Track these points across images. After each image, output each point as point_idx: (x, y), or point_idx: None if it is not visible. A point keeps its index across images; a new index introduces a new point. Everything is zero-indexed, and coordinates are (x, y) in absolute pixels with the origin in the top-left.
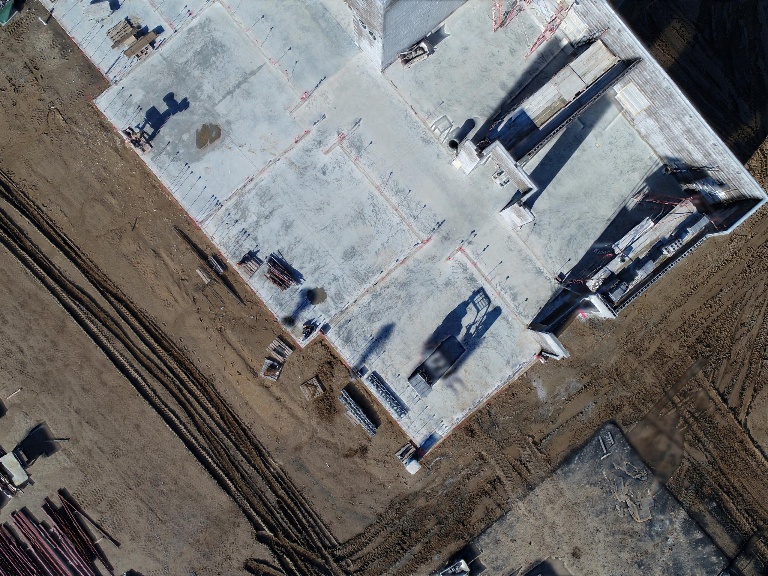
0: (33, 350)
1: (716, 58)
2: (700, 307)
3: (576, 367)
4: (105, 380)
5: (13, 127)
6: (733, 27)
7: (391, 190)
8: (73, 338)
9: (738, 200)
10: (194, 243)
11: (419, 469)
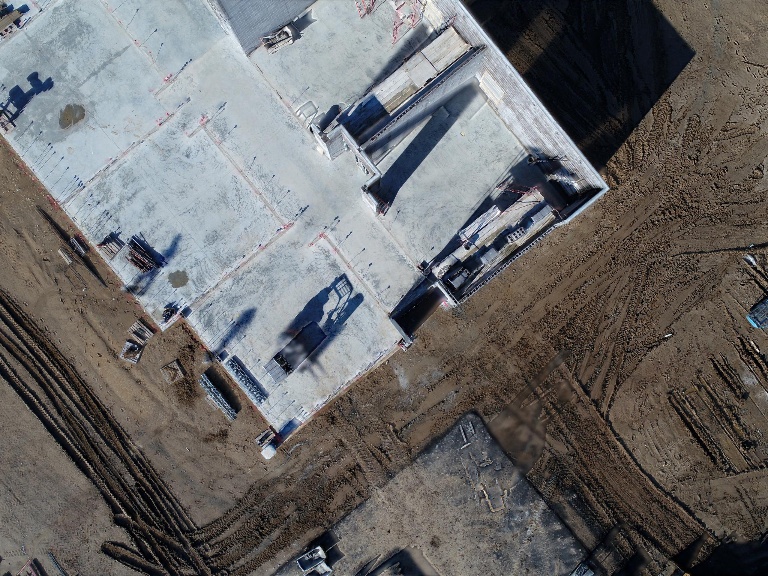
0: None
1: (585, 49)
2: (564, 298)
3: (438, 356)
4: None
5: None
6: (602, 19)
7: (255, 174)
8: None
9: (587, 190)
10: (56, 224)
11: (277, 455)
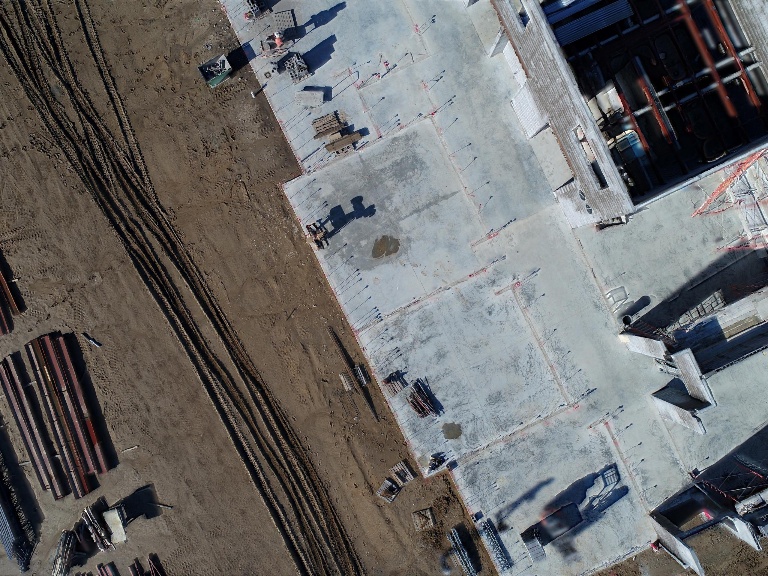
0: (159, 411)
1: None
2: None
3: None
4: (222, 459)
5: (196, 189)
6: None
7: (551, 346)
8: (201, 410)
9: None
10: (344, 348)
11: None
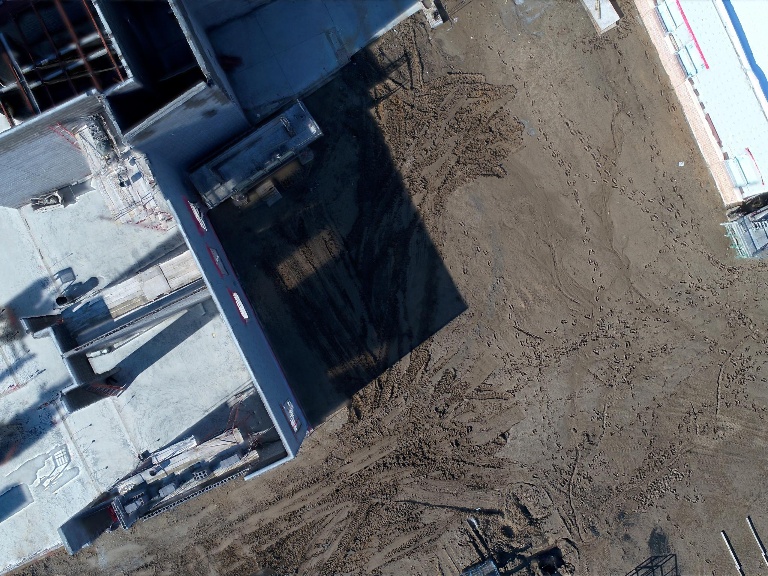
0: None
1: (357, 279)
2: (279, 517)
3: (142, 544)
4: None
5: None
6: (381, 253)
7: None
8: None
9: None
10: None
11: None
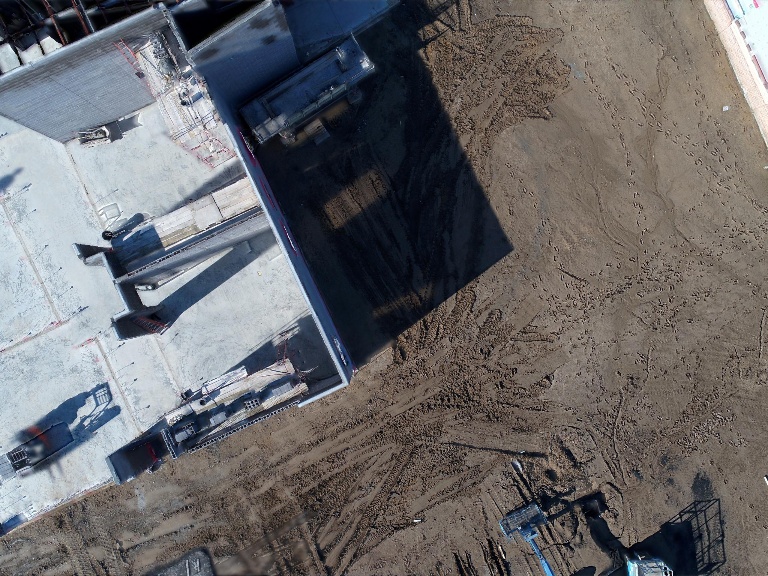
0: None
1: (404, 219)
2: (322, 459)
3: (183, 486)
4: None
5: None
6: (428, 193)
7: (42, 262)
8: None
9: None
10: None
11: None
